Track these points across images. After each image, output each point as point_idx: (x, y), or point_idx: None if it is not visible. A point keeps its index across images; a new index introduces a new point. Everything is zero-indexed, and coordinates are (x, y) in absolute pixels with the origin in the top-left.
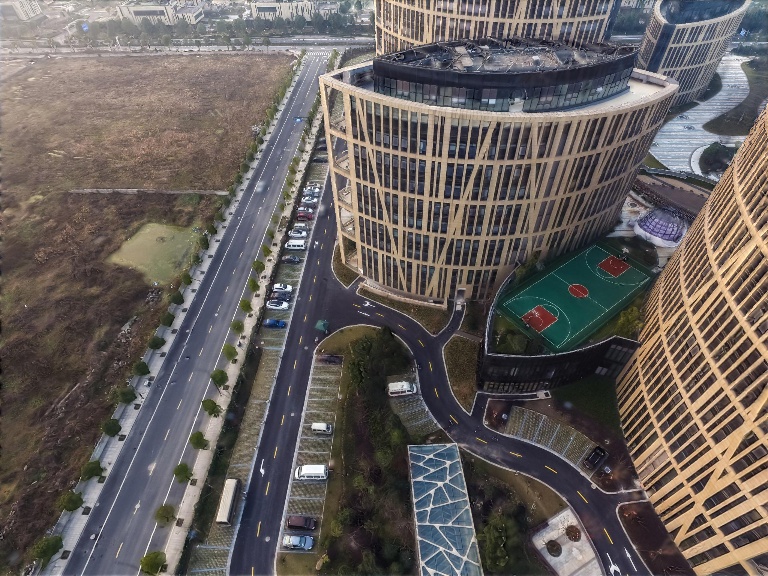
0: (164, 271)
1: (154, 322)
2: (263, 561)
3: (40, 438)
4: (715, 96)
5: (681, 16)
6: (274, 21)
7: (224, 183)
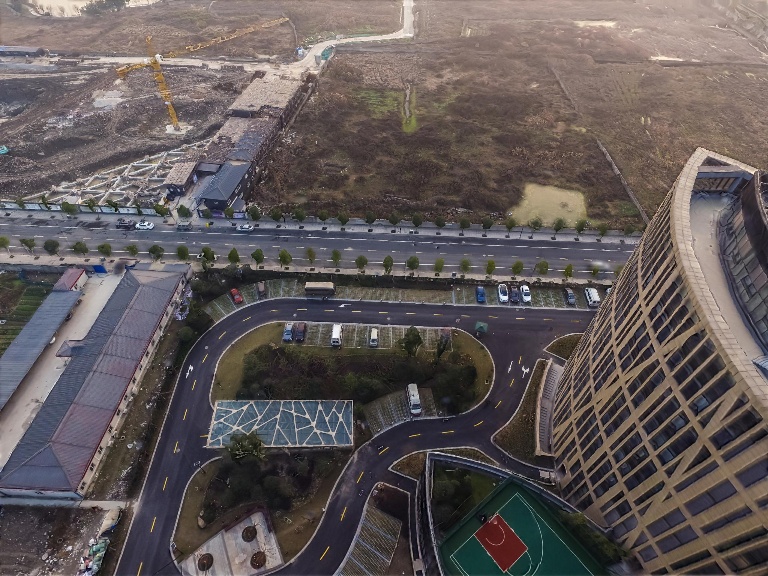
0: (526, 215)
1: None
2: (282, 315)
3: (371, 197)
4: None
5: None
6: None
7: None
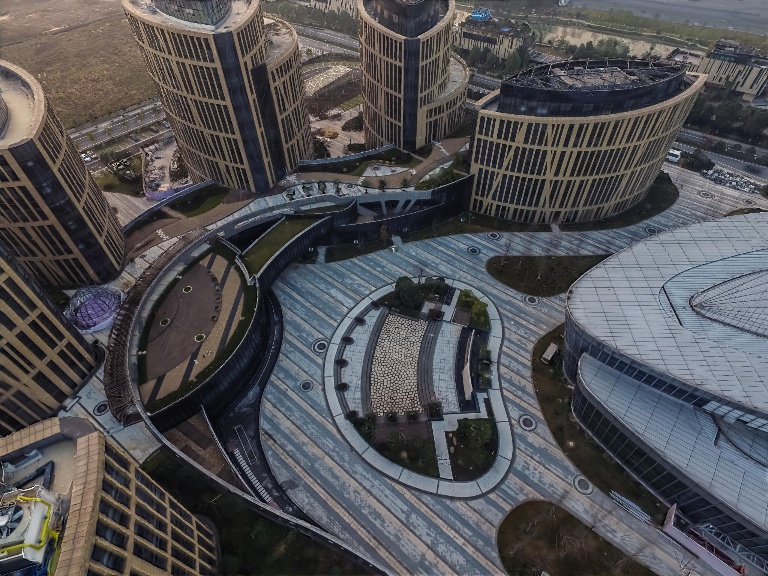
0: None
1: None
2: None
3: None
4: (594, 231)
5: (502, 101)
6: (312, 12)
7: None
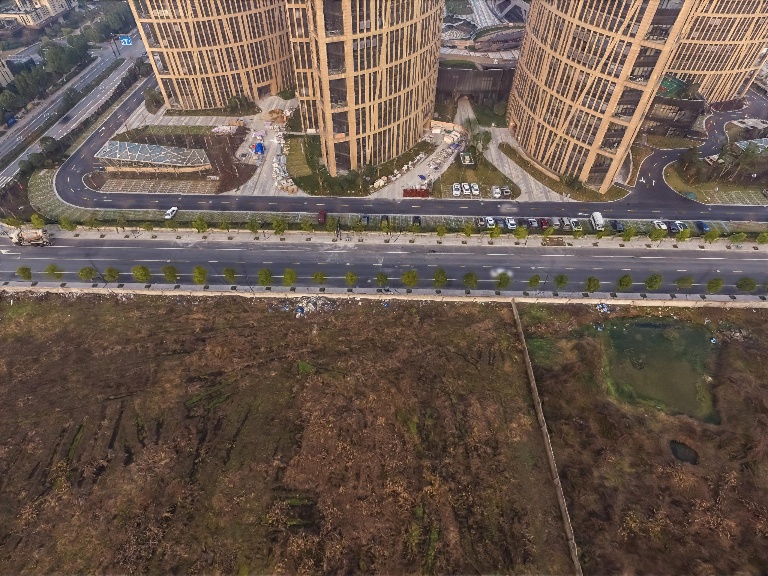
0: (690, 339)
1: (767, 318)
2: None
3: None
4: None
5: None
6: None
7: (486, 317)
